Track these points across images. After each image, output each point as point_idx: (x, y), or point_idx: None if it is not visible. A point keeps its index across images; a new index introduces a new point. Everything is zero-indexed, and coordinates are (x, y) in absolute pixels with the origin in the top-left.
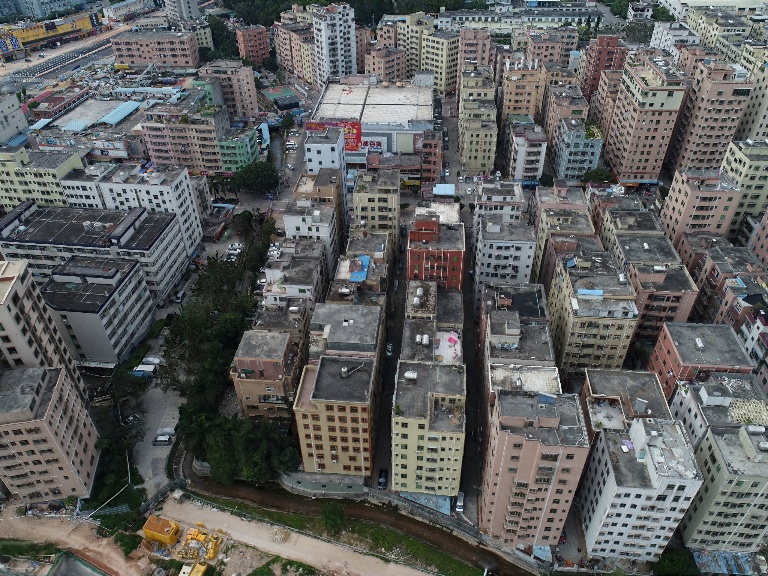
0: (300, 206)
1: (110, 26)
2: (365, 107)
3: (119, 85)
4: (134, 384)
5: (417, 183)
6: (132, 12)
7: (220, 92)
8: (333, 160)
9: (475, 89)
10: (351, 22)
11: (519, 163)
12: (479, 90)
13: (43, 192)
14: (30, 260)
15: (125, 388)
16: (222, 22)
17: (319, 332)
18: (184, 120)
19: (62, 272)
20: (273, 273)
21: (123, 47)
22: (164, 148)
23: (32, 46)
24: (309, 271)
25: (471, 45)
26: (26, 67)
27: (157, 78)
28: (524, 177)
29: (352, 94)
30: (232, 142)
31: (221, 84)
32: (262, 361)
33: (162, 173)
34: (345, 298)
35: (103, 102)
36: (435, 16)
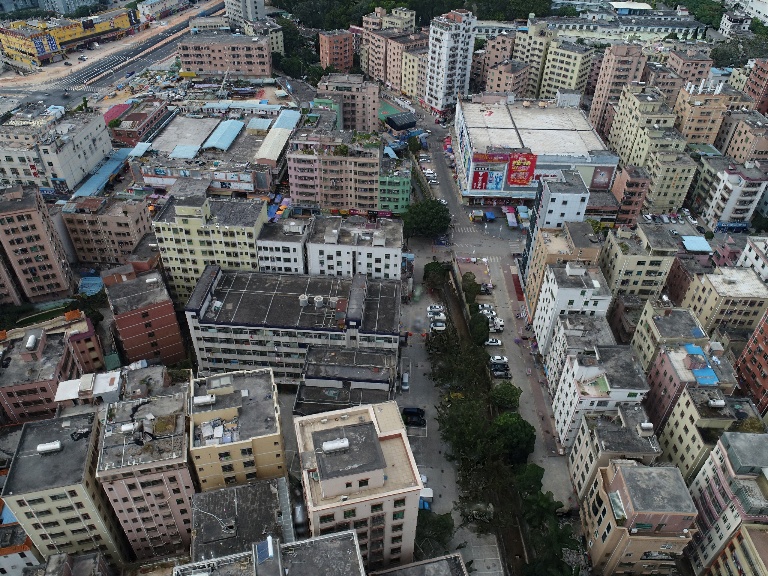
0: (572, 274)
1: (148, 24)
2: (519, 132)
3: (190, 96)
4: (444, 528)
5: (610, 225)
6: (167, 9)
7: (342, 111)
8: (579, 212)
9: (655, 115)
10: (472, 32)
11: (730, 203)
12: (659, 116)
13: (229, 253)
14: (231, 345)
15: (426, 532)
16: (293, 25)
17: (749, 476)
18: (340, 151)
19: (320, 375)
20: (587, 371)
21: (191, 52)
22: (310, 183)
23: (68, 47)
24: (628, 366)
25: (625, 62)
26: (69, 72)
27: (231, 88)
28: (731, 218)
29: (494, 116)
30: (396, 177)
31: (342, 102)
32: (670, 515)
33: (385, 231)
34: (721, 413)
35: (196, 120)
36: (523, 23)
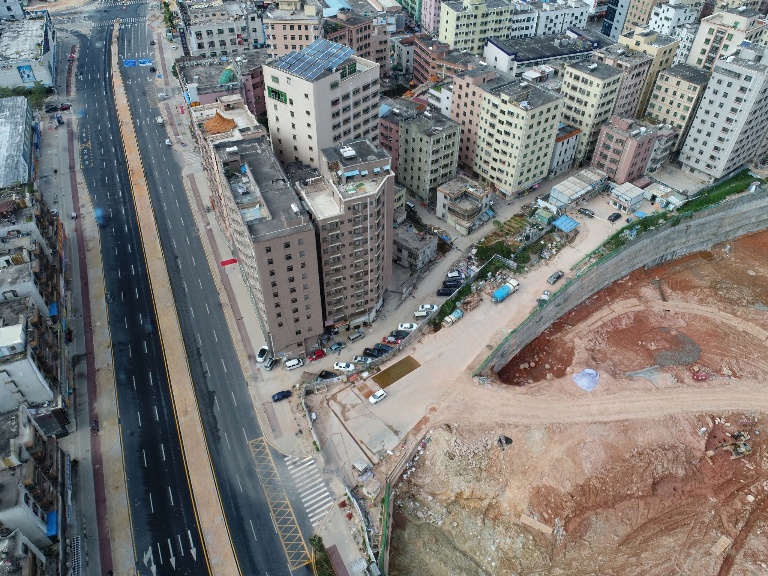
0: (675, 4)
1: None
2: None
3: None
4: None
5: None
6: None
7: None
8: None
9: None
10: None
11: None
12: None
13: (495, 30)
14: None
15: None
16: None
17: None
18: None
19: None
20: None
21: None
22: None
23: None
24: None
25: None
26: None
27: None
28: None
29: None
30: None
31: None
32: None
33: None
34: None
35: None
36: None
